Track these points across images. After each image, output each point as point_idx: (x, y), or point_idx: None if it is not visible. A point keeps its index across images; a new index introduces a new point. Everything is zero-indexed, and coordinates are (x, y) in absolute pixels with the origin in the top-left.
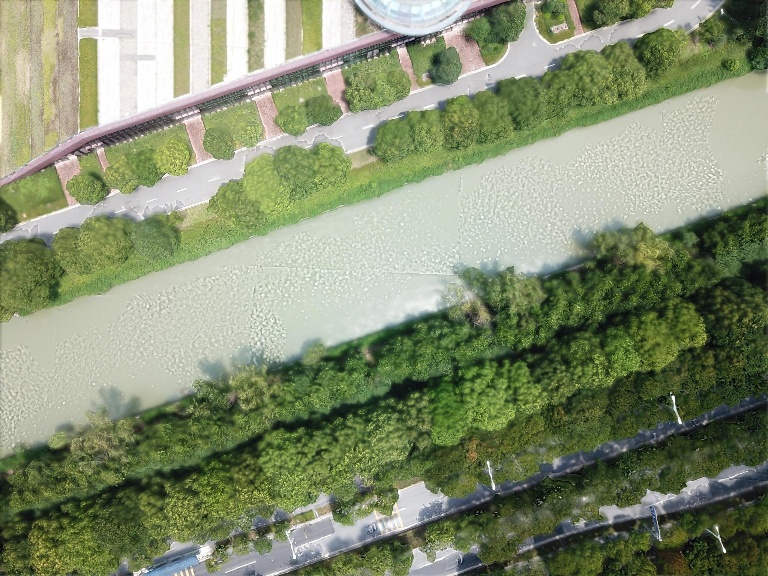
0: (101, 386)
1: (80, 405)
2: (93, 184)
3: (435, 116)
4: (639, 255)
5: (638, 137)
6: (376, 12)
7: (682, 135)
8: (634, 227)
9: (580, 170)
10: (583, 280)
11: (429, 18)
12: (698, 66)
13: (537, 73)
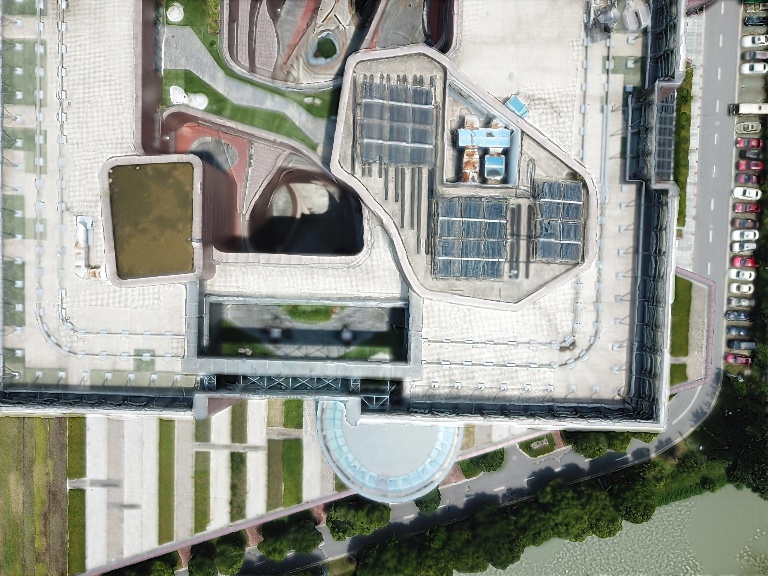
0: None
1: None
2: None
3: (411, 567)
4: None
5: (617, 534)
6: (354, 481)
7: (661, 532)
8: None
9: (558, 567)
10: None
11: (406, 488)
12: (677, 483)
13: (516, 485)
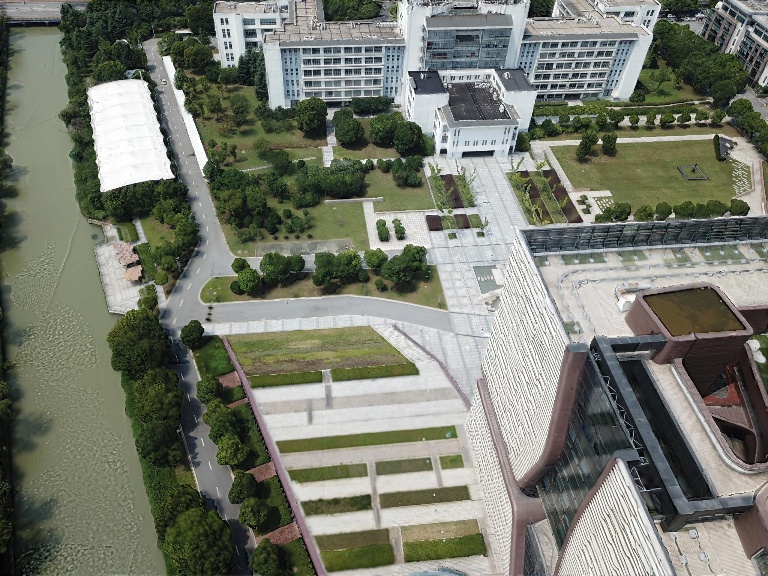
0: (45, 418)
1: (33, 405)
2: (210, 392)
3: None
4: None
5: None
6: None
7: None
8: None
9: None
10: None
11: None
12: None
13: None
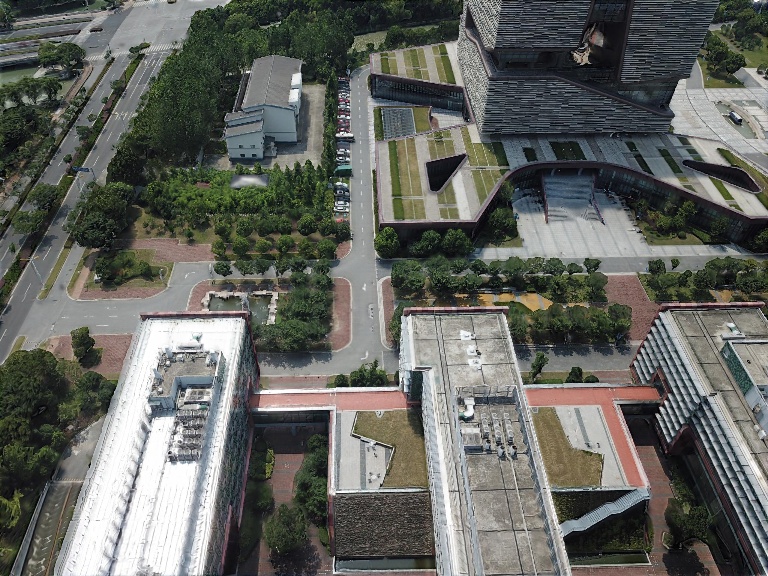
0: None
1: None
2: None
3: None
4: (398, 2)
5: None
6: None
7: None
8: None
9: None
10: (417, 2)
11: None
12: None
13: None
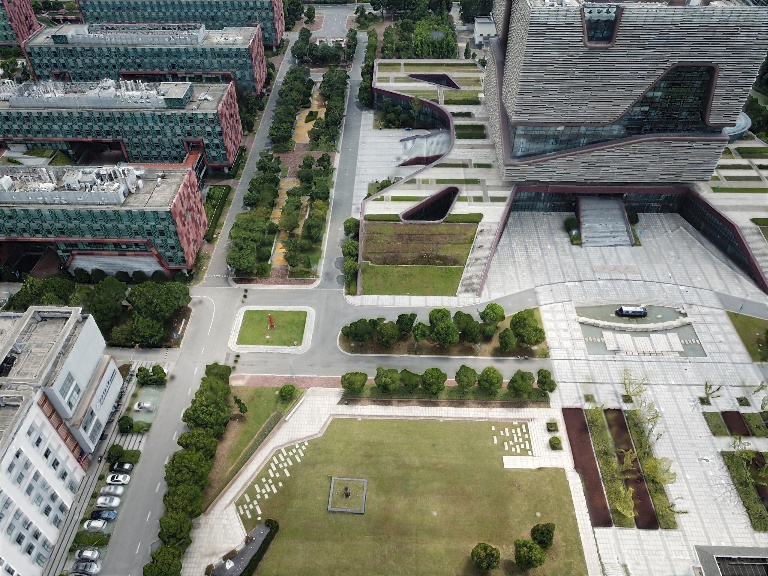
0: None
1: None
2: None
3: None
4: None
5: None
6: None
7: None
8: (763, 98)
9: None
10: None
11: None
12: None
13: None
